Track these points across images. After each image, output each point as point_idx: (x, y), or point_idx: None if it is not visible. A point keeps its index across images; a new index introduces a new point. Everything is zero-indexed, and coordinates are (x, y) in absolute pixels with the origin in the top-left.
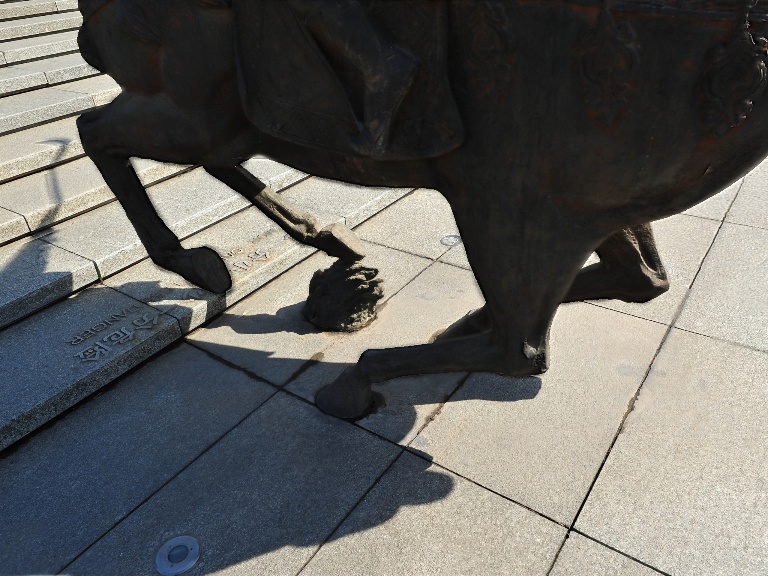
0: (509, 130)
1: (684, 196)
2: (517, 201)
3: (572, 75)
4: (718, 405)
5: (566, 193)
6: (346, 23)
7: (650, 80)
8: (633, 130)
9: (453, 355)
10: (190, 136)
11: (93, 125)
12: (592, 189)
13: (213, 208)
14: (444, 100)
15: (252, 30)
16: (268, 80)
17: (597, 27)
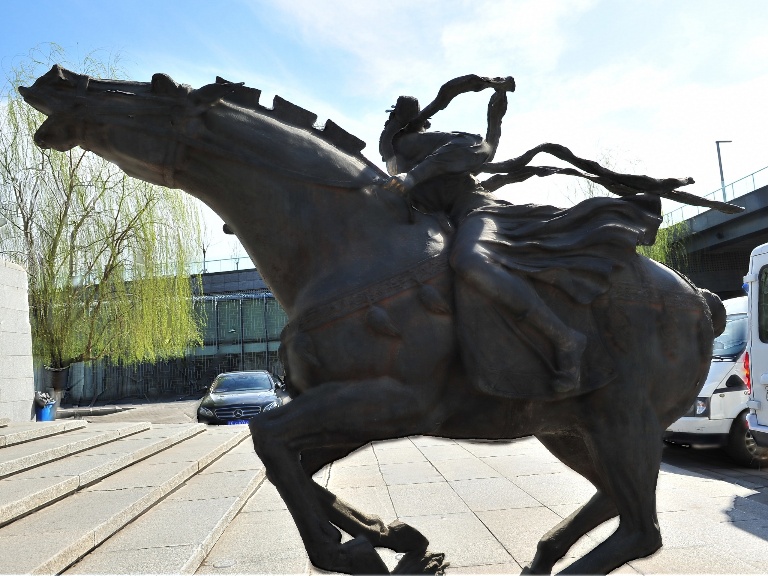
0: (635, 366)
1: (690, 401)
2: (639, 410)
3: (657, 335)
4: (698, 575)
5: (658, 401)
6: (549, 315)
7: (684, 336)
8: (683, 360)
9: (609, 554)
10: (411, 406)
11: (283, 419)
12: (669, 396)
13: (181, 573)
14: (603, 353)
15: (469, 326)
16: (482, 356)
17: (664, 313)
